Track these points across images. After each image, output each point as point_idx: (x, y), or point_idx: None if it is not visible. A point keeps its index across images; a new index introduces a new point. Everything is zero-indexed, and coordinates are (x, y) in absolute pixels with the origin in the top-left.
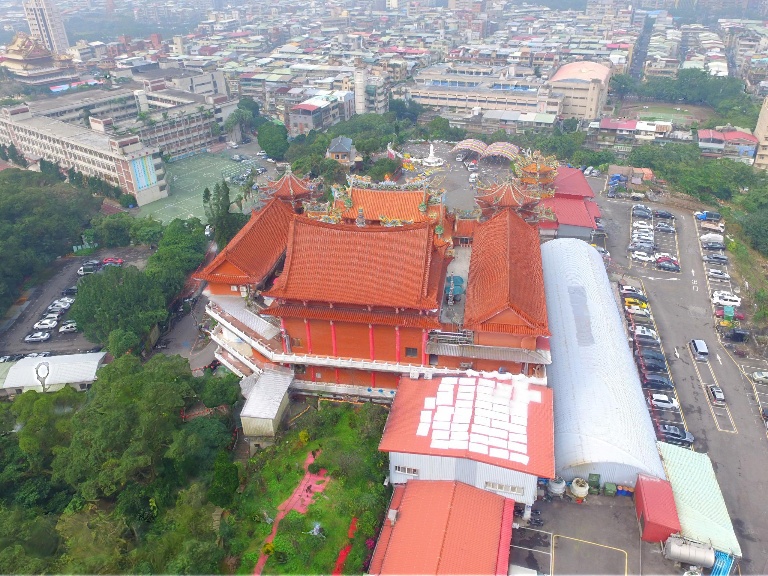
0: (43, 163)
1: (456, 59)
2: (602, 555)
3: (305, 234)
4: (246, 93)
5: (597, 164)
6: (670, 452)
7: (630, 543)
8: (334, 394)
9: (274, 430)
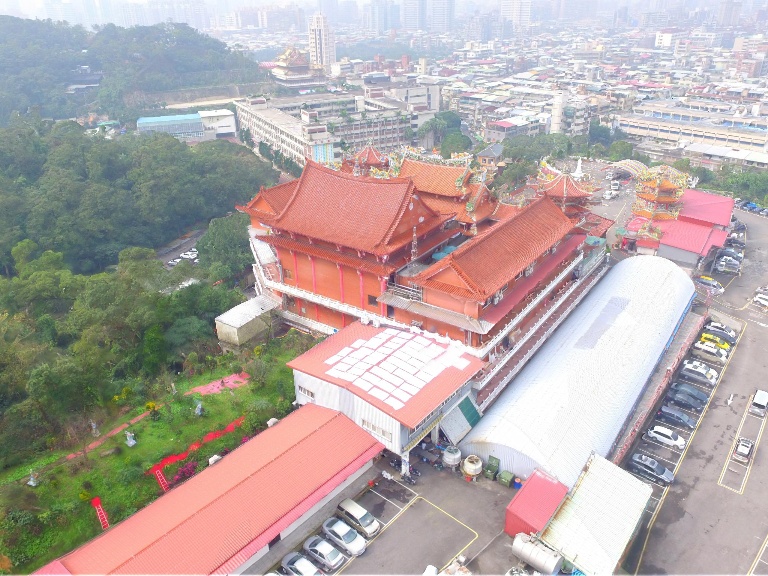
0: (261, 145)
1: (697, 95)
2: (451, 528)
3: (312, 177)
4: (463, 111)
5: None
6: (602, 468)
7: (489, 529)
8: (309, 329)
9: (240, 340)
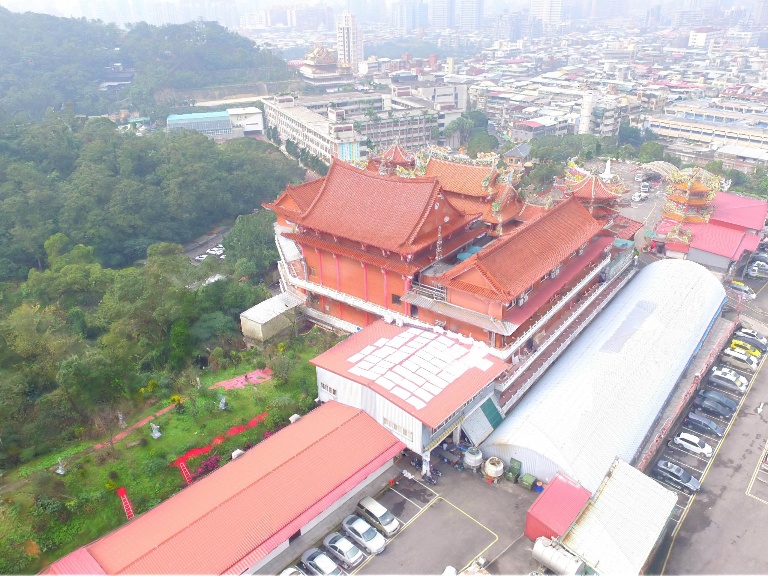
0: (288, 142)
1: (732, 96)
2: (471, 529)
3: (339, 176)
4: (490, 110)
5: None
6: (626, 474)
7: (510, 532)
8: (332, 326)
9: (264, 336)
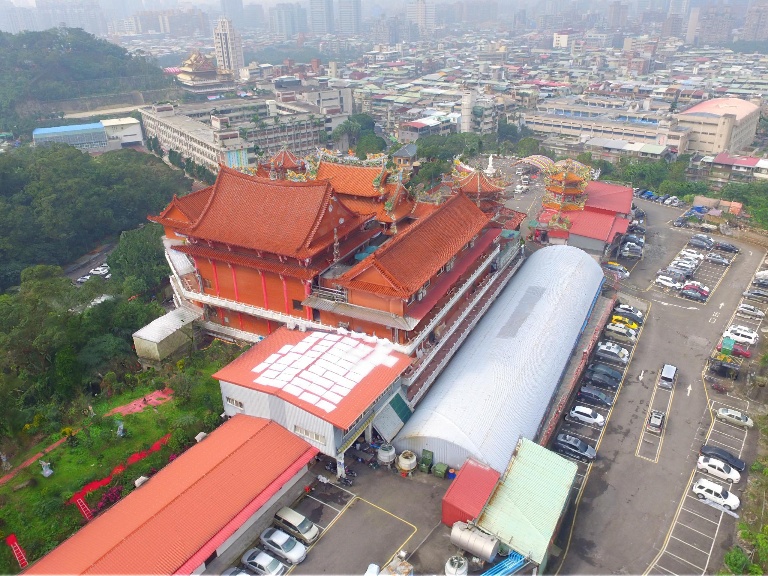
0: (171, 153)
1: (594, 92)
2: (390, 525)
3: (228, 183)
4: (376, 113)
5: (684, 195)
6: (531, 451)
7: (427, 522)
8: (234, 338)
9: (161, 355)
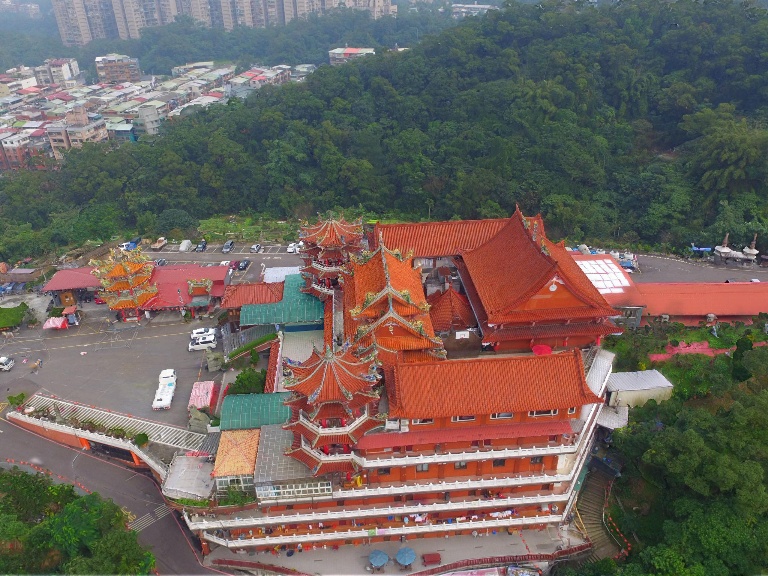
0: None
1: None
2: None
3: None
4: None
5: None
6: None
7: None
8: None
9: None
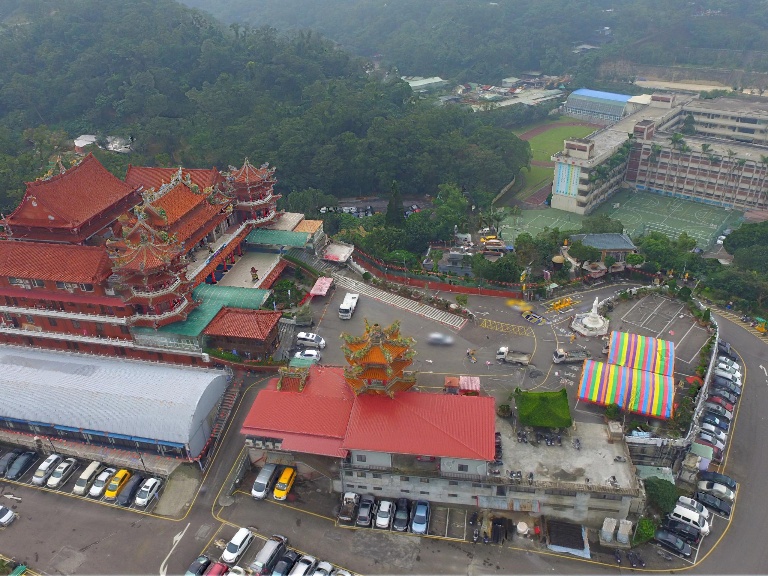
0: None
1: None
2: None
3: None
4: None
5: None
6: None
7: None
8: None
9: None
